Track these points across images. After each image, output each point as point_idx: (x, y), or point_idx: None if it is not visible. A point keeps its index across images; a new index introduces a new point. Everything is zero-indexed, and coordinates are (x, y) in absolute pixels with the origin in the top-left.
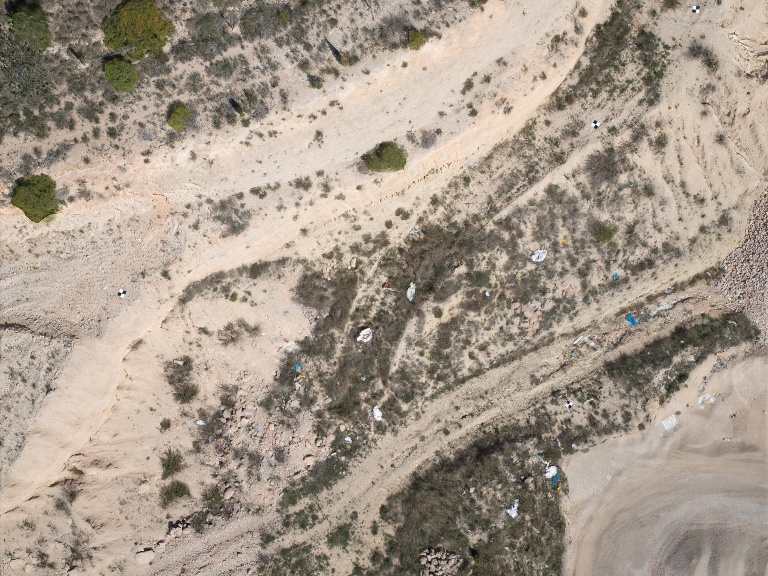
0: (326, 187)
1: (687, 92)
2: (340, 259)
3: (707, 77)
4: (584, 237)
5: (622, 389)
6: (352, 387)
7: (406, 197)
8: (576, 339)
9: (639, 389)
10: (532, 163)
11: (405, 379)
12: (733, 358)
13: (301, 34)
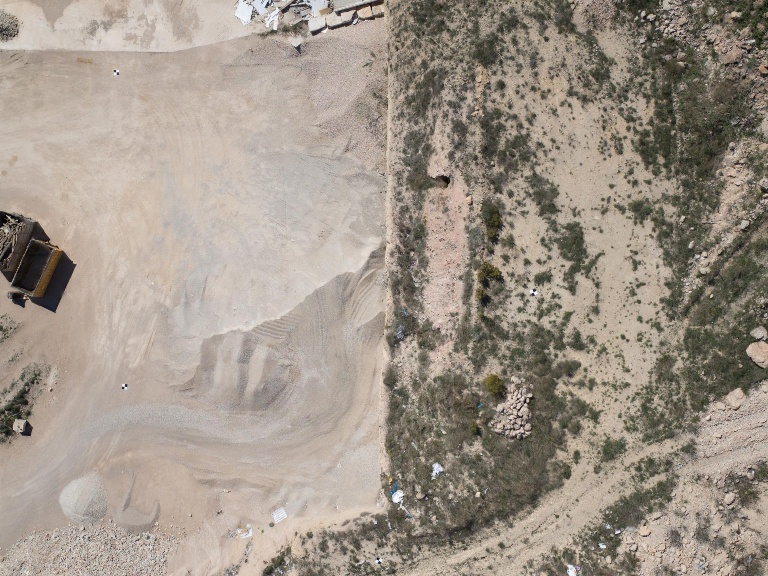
0: None
1: None
2: None
3: None
4: None
5: (327, 573)
6: None
7: None
8: None
9: (311, 572)
10: None
11: None
12: None
13: None
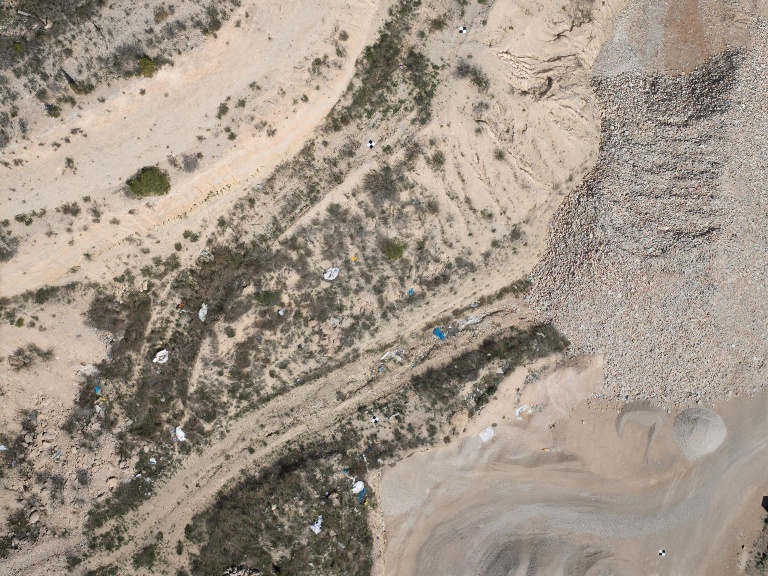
0: (96, 212)
1: (458, 111)
2: (132, 282)
3: (478, 95)
4: (375, 254)
5: (427, 403)
6: (152, 408)
7: (191, 220)
8: (383, 355)
9: (444, 403)
10: (313, 183)
11: (205, 399)
12: (545, 369)
13: (37, 64)
